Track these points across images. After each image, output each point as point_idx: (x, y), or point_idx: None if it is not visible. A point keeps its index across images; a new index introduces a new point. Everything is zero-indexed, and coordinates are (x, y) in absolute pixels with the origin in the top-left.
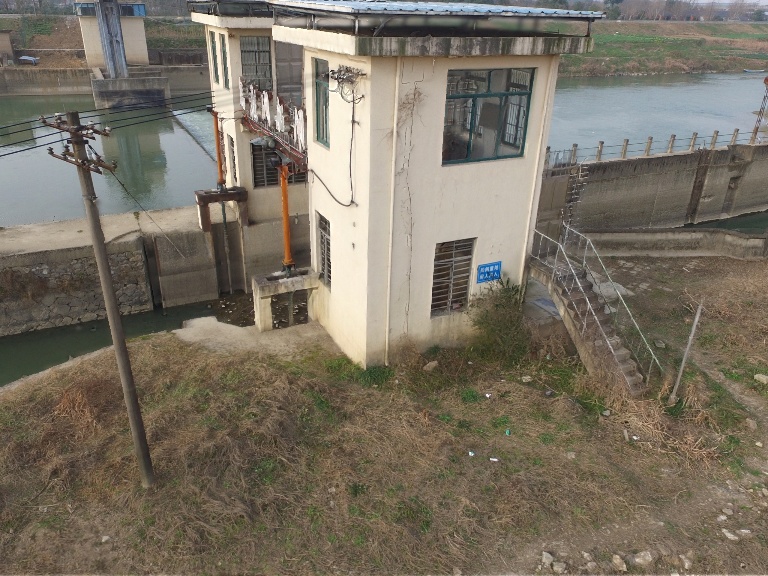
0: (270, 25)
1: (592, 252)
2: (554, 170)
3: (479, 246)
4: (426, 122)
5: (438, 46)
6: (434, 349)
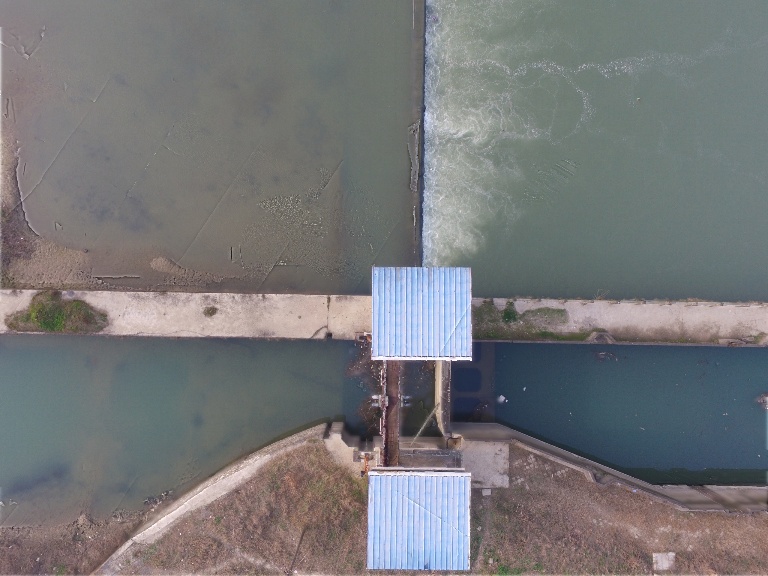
0: None
1: None
2: None
3: None
4: None
5: None
6: None
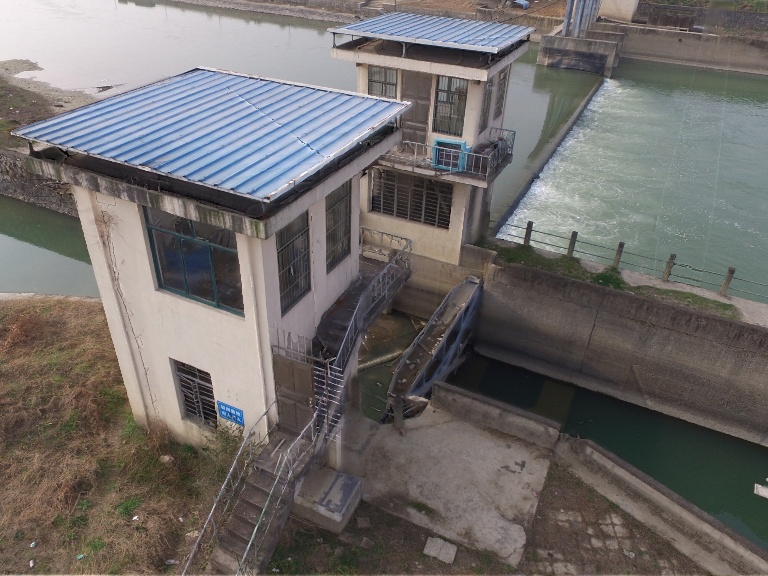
0: (377, 62)
1: (596, 478)
2: (289, 350)
3: (214, 382)
4: (130, 244)
5: (89, 181)
6: (186, 447)
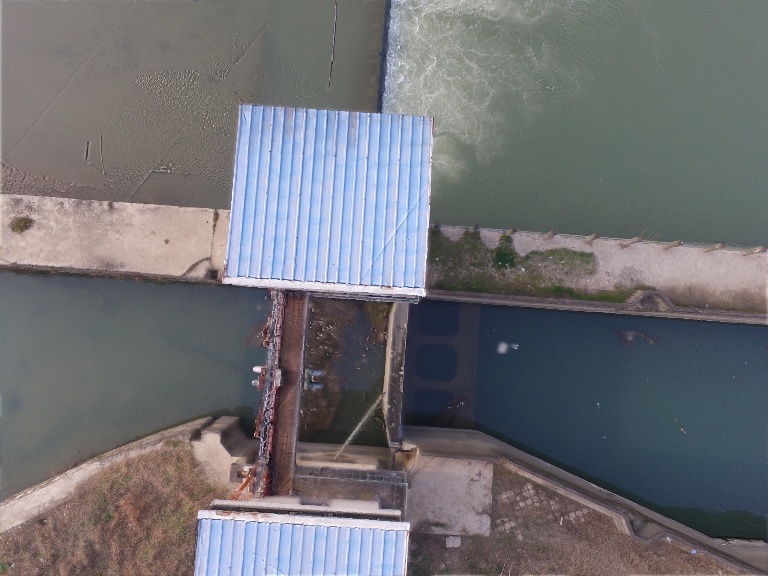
0: None
1: None
2: None
3: None
4: None
5: None
6: None
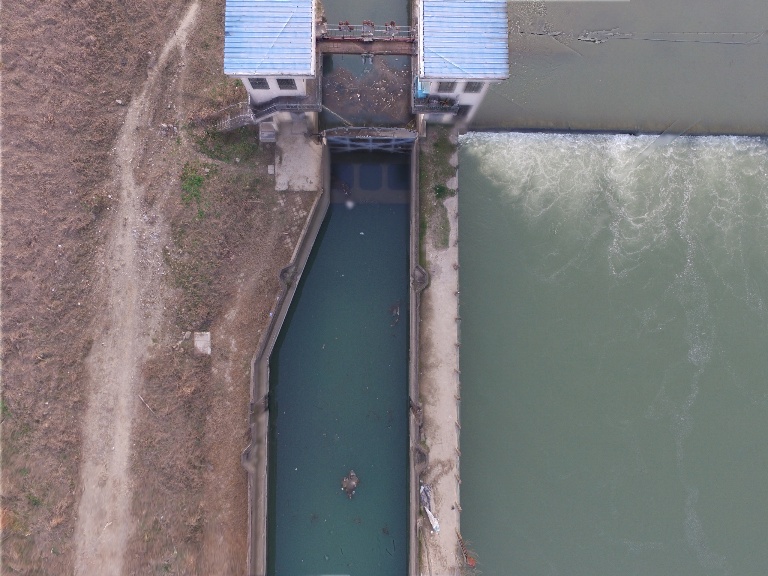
0: None
1: None
2: None
3: None
4: None
5: None
6: None
